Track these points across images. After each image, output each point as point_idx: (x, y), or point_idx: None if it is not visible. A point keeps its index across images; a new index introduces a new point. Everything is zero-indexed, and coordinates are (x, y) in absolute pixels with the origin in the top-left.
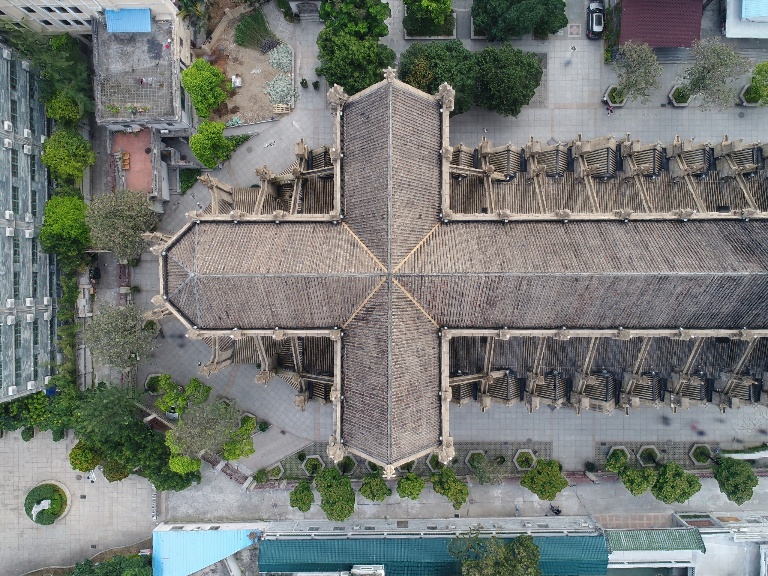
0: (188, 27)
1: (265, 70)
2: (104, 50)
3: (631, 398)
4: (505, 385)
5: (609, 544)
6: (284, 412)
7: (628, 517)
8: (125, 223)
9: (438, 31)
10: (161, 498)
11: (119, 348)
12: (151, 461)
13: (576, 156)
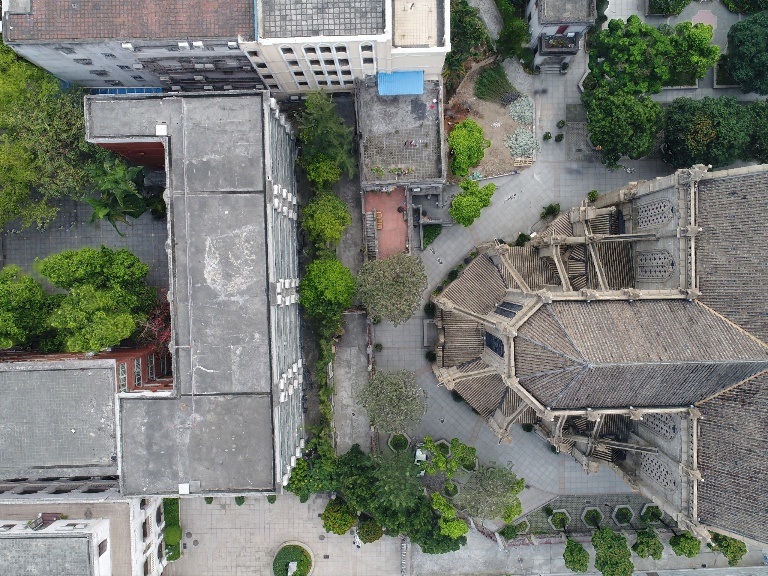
0: (444, 85)
1: (506, 123)
2: (366, 111)
3: None
4: None
5: None
6: (528, 466)
7: None
8: (406, 289)
9: (681, 81)
10: (406, 556)
11: (402, 416)
12: (422, 525)
13: None
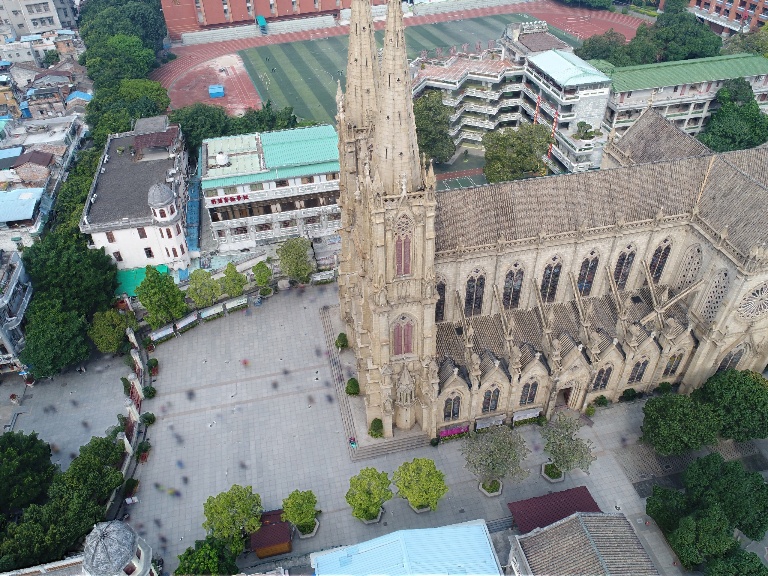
0: None
1: None
2: None
3: None
4: None
5: None
6: None
7: None
8: None
9: None
10: None
11: None
12: None
13: None
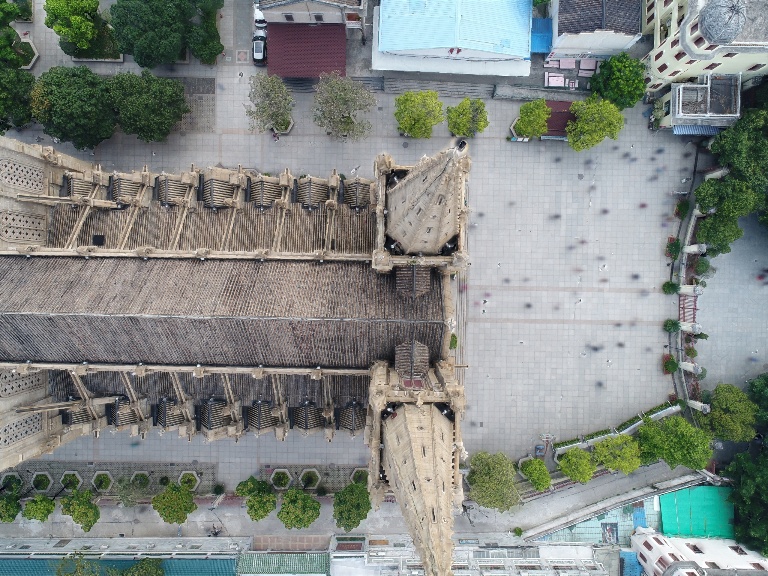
0: None
1: None
2: None
3: (227, 427)
4: (115, 411)
5: (237, 567)
6: None
7: (289, 539)
8: None
9: (104, 54)
10: None
11: None
12: None
13: (186, 186)
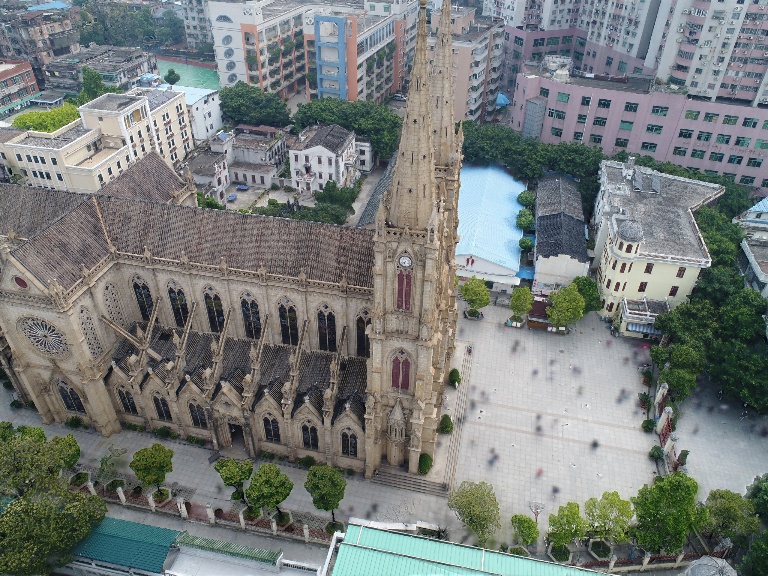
0: None
1: None
2: None
3: None
4: None
5: None
6: None
7: None
8: None
9: None
10: None
11: None
12: None
13: None
